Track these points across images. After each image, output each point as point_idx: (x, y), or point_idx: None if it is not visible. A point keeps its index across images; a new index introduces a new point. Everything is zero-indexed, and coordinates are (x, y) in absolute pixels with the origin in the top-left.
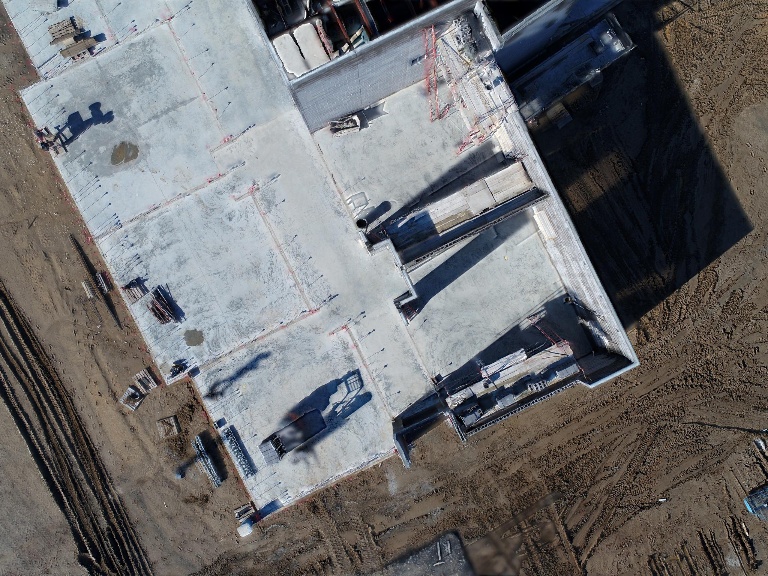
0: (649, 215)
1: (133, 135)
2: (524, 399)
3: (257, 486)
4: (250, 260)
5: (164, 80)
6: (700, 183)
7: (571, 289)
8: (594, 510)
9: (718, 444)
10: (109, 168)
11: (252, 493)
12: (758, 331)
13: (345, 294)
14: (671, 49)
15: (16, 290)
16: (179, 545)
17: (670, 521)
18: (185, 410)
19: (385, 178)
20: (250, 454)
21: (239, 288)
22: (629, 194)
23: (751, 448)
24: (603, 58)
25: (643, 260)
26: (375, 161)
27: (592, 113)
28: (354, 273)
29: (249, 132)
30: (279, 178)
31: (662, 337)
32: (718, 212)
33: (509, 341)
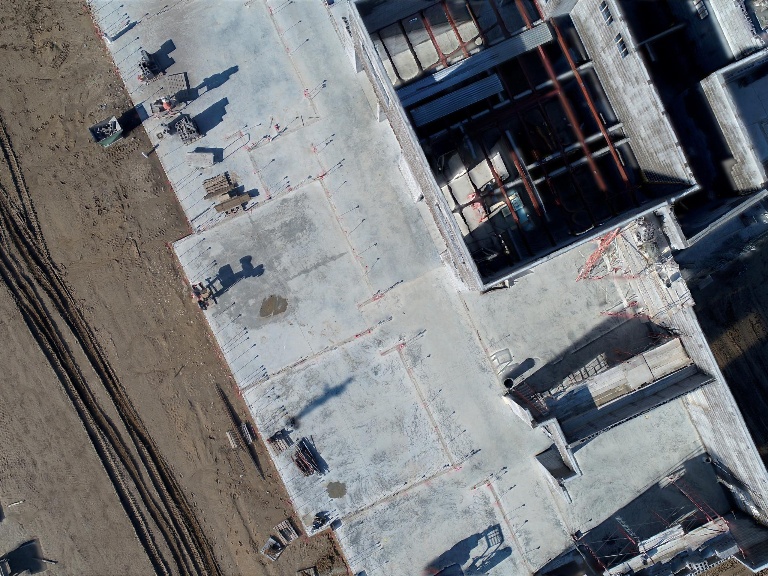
0: None
1: (282, 288)
2: None
3: None
4: (394, 414)
5: (315, 235)
6: None
7: (715, 453)
8: None
9: None
10: (258, 320)
11: None
12: None
13: (487, 449)
14: None
15: (160, 438)
16: None
17: None
18: (325, 561)
19: (529, 335)
20: None
21: (383, 441)
22: (767, 354)
23: None
24: (751, 229)
25: None
26: (520, 319)
27: (732, 274)
28: (497, 428)
29: (397, 288)
30: (425, 333)
31: None
32: None
33: (649, 499)
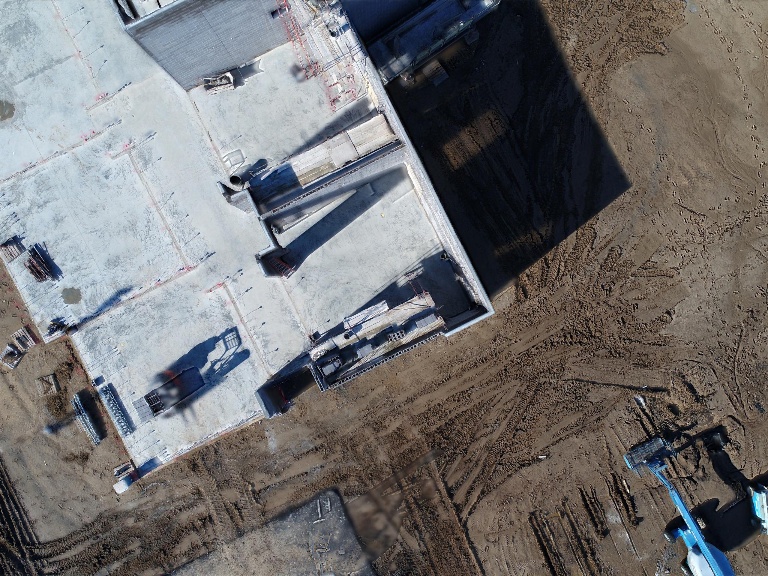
0: (527, 172)
1: (9, 93)
2: (390, 352)
3: (136, 444)
4: (127, 218)
5: (40, 38)
6: (577, 140)
7: (444, 245)
8: (474, 467)
9: (598, 401)
10: None
11: (131, 451)
12: (637, 288)
13: (222, 252)
14: (547, 6)
15: None
16: (60, 504)
17: (551, 478)
18: (64, 368)
19: (261, 136)
20: (129, 412)
21: (116, 246)
22: (506, 151)
23: (631, 405)
24: (473, 13)
25: (521, 217)
26: (251, 119)
27: (469, 70)
28: (231, 231)
29: (125, 90)
30: (155, 136)
31: (541, 294)
32: (596, 169)
33: (386, 298)
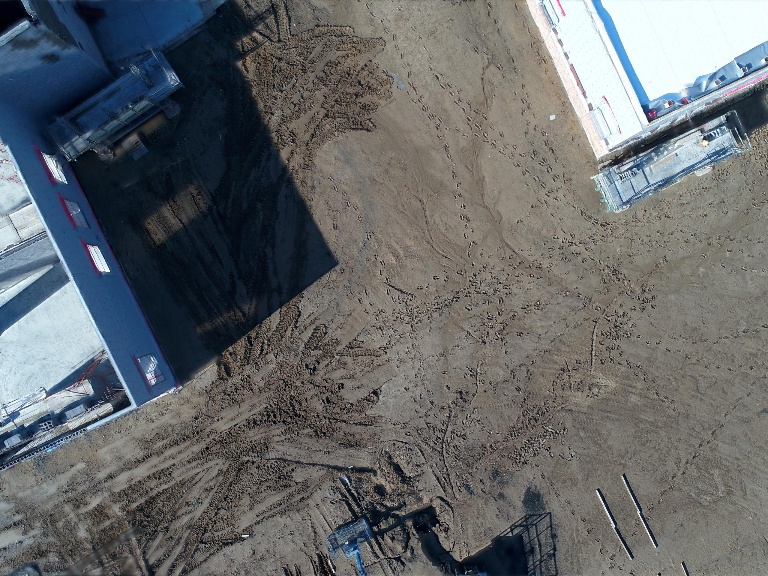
0: (229, 249)
1: None
2: (57, 437)
3: None
4: None
5: None
6: (281, 217)
7: None
8: (176, 545)
9: (302, 480)
10: None
11: None
12: (343, 367)
13: None
14: (251, 81)
15: None
16: None
17: (254, 557)
18: None
19: None
20: None
21: None
22: (209, 227)
23: (337, 485)
24: None
25: (224, 294)
26: None
27: (170, 145)
28: None
29: None
30: None
31: (244, 372)
32: (300, 247)
33: None
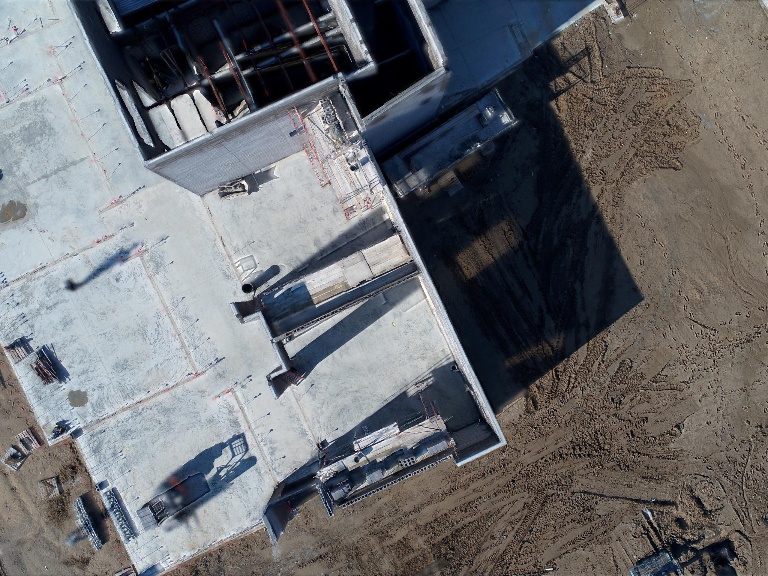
0: (539, 284)
1: (22, 194)
2: (399, 472)
3: (138, 550)
4: (137, 321)
5: (54, 139)
6: (590, 253)
7: (456, 358)
8: None
9: (606, 514)
10: None
11: (133, 557)
12: (647, 401)
13: (232, 357)
14: (563, 119)
15: None
16: None
17: None
18: (68, 471)
19: (274, 242)
20: (132, 517)
21: (125, 349)
22: (519, 262)
23: (639, 518)
24: (489, 130)
25: (532, 328)
26: (265, 225)
27: (483, 181)
28: (241, 336)
29: (139, 193)
30: (168, 240)
31: (551, 406)
32: (608, 282)
33: (396, 407)
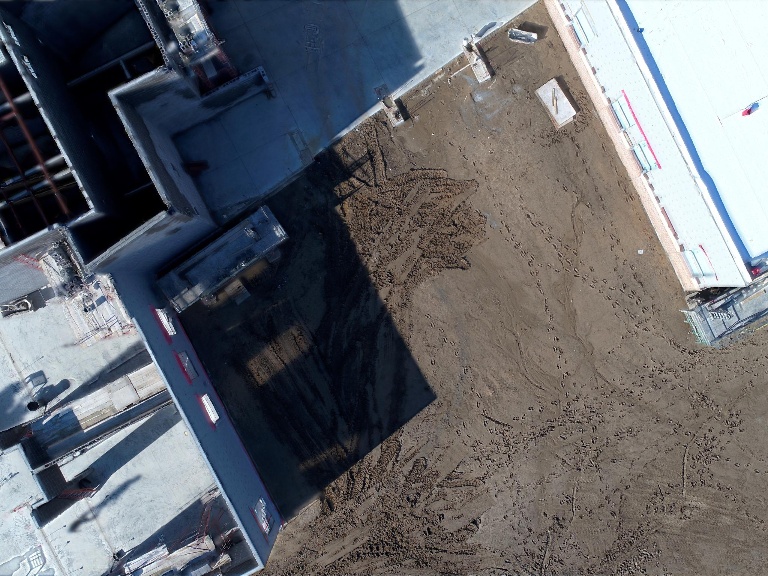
0: (331, 387)
1: None
2: None
3: None
4: None
5: None
6: (380, 355)
7: None
8: None
9: None
10: None
11: None
12: (443, 498)
13: (26, 472)
14: (349, 223)
15: None
16: None
17: None
18: None
19: (63, 356)
20: None
21: None
22: (310, 367)
23: None
24: (264, 243)
25: (326, 431)
26: (53, 340)
27: (271, 288)
28: None
29: None
30: None
31: (347, 506)
32: (399, 383)
33: (191, 515)
